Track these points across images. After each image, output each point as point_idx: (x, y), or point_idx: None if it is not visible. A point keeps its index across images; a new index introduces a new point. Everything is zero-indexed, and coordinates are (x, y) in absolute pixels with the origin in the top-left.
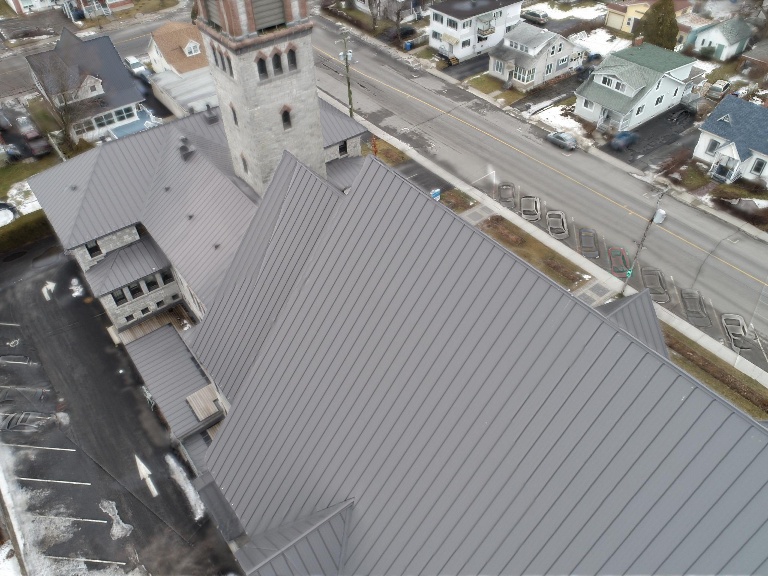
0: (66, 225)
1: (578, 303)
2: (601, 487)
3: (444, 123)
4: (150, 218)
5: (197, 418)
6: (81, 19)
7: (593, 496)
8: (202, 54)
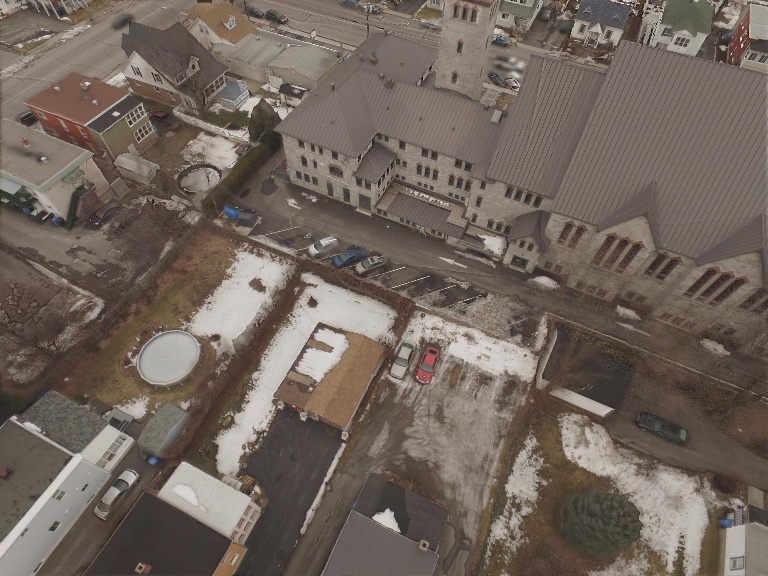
0: (345, 145)
1: (747, 70)
2: (766, 126)
3: (427, 45)
4: (386, 128)
5: (461, 227)
6: (64, 15)
7: (764, 130)
8: (238, 26)
